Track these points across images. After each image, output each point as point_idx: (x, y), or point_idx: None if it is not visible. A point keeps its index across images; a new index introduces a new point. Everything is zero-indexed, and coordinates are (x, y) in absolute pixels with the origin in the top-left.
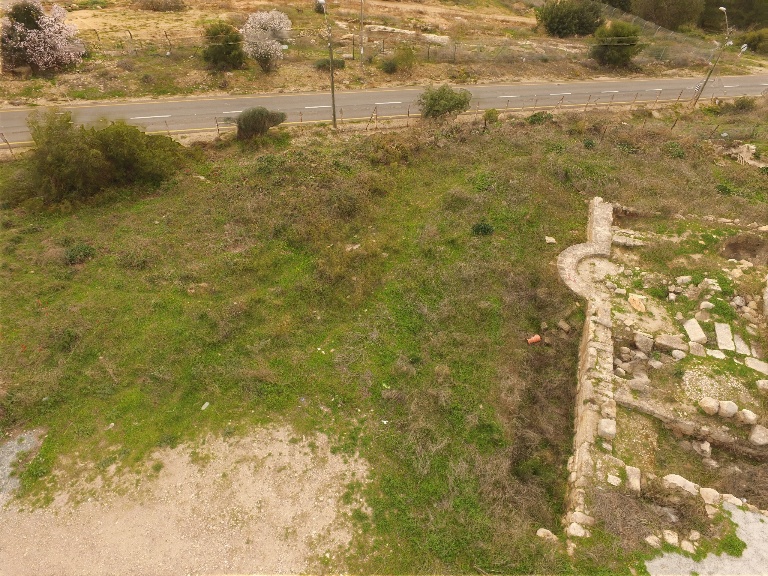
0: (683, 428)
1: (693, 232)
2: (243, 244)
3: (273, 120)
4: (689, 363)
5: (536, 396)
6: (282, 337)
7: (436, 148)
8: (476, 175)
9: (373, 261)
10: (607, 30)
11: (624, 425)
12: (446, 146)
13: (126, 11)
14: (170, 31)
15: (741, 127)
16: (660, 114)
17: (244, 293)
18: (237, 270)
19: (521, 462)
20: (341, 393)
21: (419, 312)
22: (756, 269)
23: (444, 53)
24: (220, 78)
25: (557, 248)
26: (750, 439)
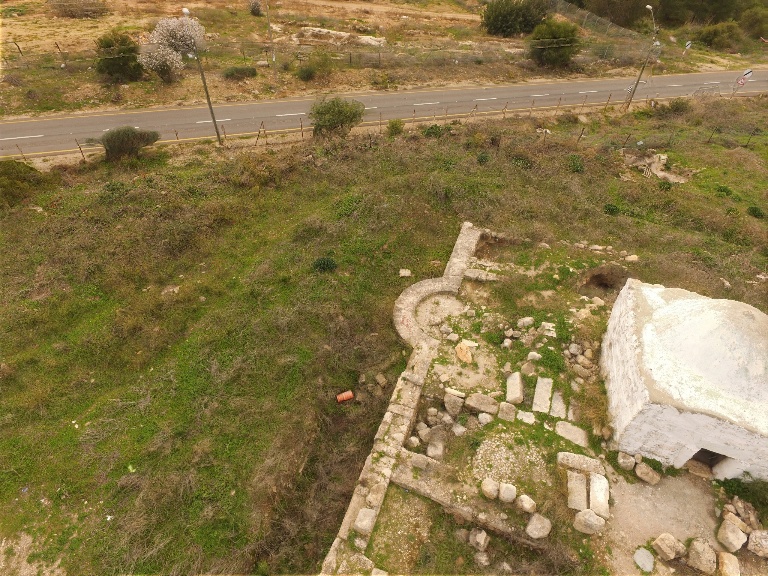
0: (462, 514)
1: (550, 264)
2: (49, 289)
3: (143, 140)
4: (493, 430)
5: (317, 471)
6: (33, 409)
7: (313, 168)
8: (344, 199)
9: (183, 308)
10: (543, 29)
11: (394, 512)
12: (323, 165)
13: (39, 19)
14: (77, 40)
15: (665, 133)
16: (588, 119)
17: (22, 351)
18: (22, 323)
19: (261, 563)
20: (71, 481)
21: (209, 371)
22: (607, 308)
23: (369, 57)
24: (114, 91)
25: (410, 282)
26: (526, 531)
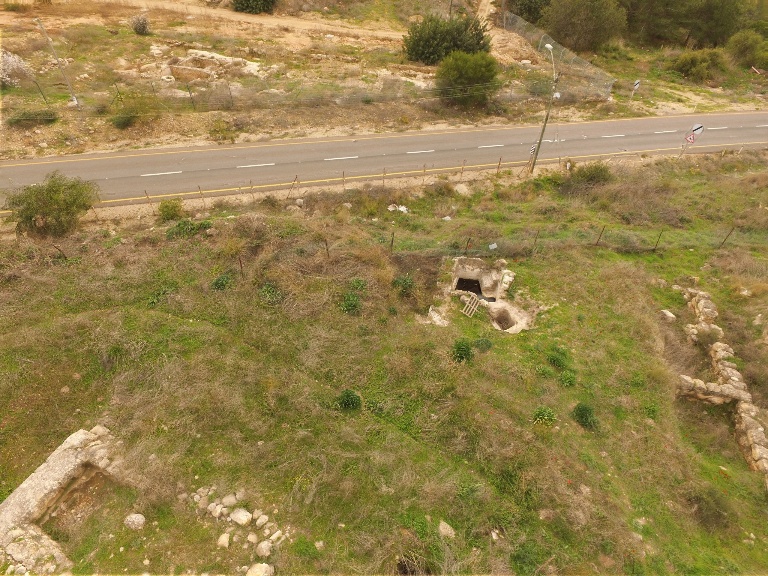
0: None
1: None
2: None
3: None
4: None
5: None
6: None
7: None
8: None
9: None
10: (449, 63)
11: None
12: None
13: None
14: None
15: (550, 222)
16: (470, 189)
17: None
18: None
19: None
20: None
21: None
22: None
23: (219, 96)
24: None
25: None
26: None
